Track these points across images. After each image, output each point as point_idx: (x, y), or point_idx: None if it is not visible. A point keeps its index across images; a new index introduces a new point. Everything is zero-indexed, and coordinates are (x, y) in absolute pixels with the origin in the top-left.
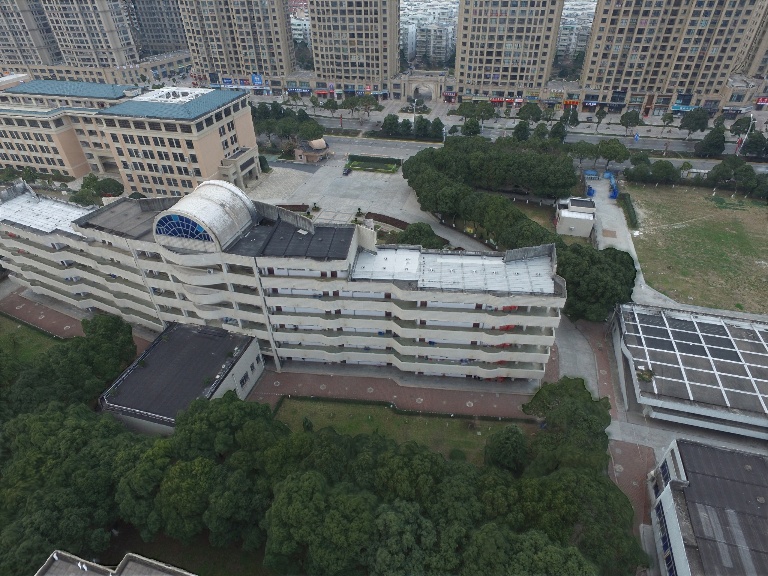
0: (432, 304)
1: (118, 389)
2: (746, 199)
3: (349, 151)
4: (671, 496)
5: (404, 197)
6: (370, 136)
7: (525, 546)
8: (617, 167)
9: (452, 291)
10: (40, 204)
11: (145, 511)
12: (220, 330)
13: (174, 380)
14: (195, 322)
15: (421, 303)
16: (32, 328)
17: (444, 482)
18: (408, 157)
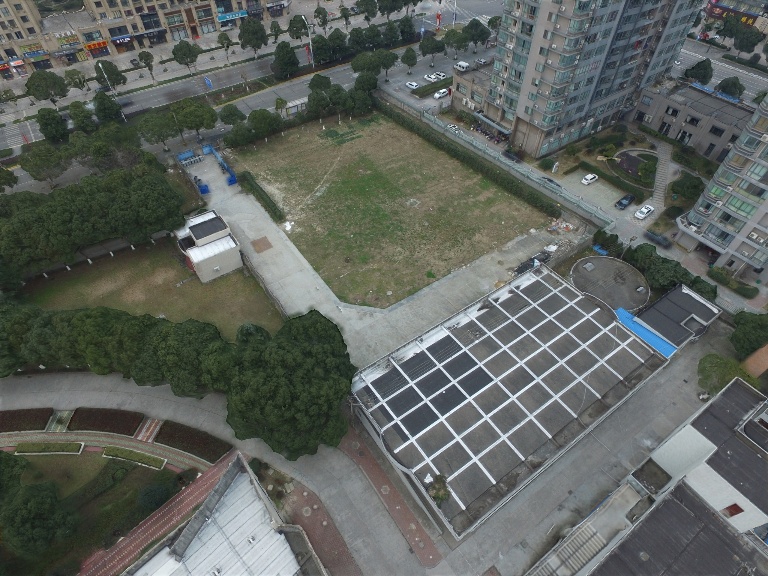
0: None
1: None
2: (352, 121)
3: None
4: None
5: None
6: None
7: None
8: None
9: None
10: None
11: None
12: None
13: None
14: None
15: None
16: None
17: None
18: None
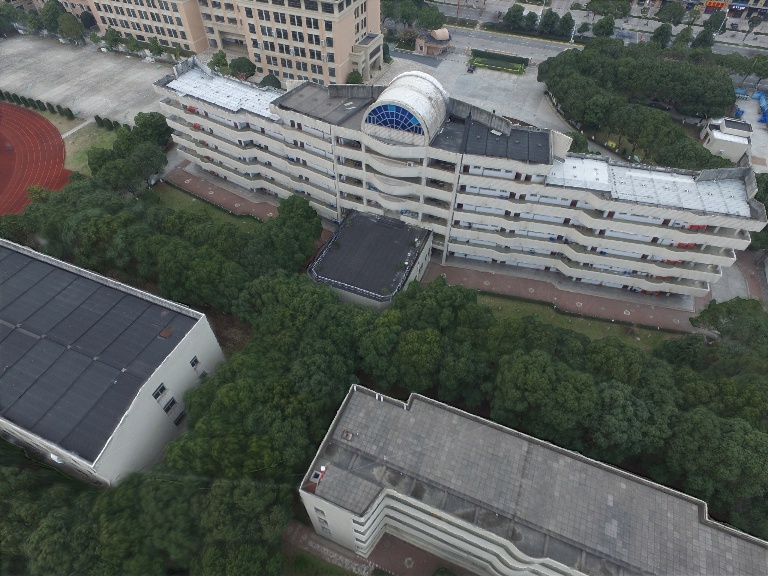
0: (619, 216)
1: (321, 265)
2: None
3: (469, 45)
4: None
5: (536, 102)
6: (489, 29)
7: (736, 428)
8: (766, 87)
9: (647, 205)
10: (214, 81)
11: (386, 366)
12: (398, 221)
13: (368, 262)
14: (373, 211)
15: (609, 214)
16: (207, 202)
17: (649, 372)
18: (533, 57)
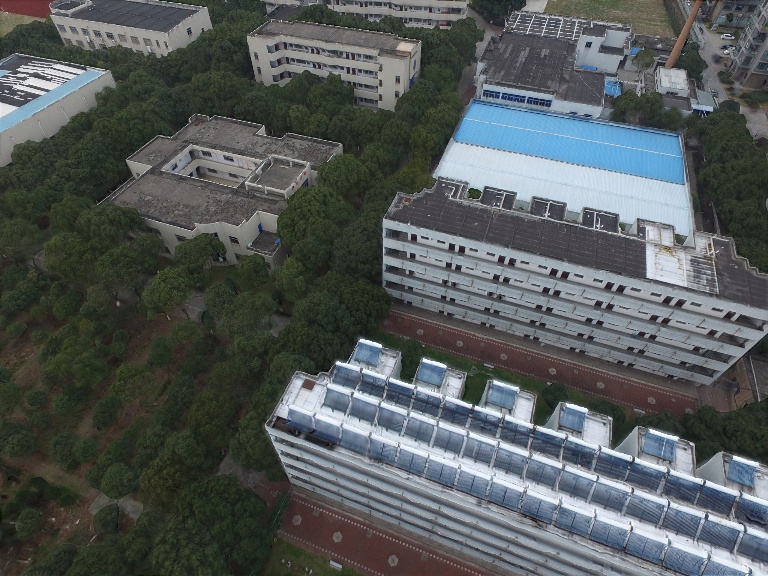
0: None
1: None
2: None
3: None
4: (490, 39)
5: None
6: None
7: None
8: None
9: None
10: None
11: None
12: None
13: None
14: (294, 3)
15: None
16: None
17: (404, 27)
18: None
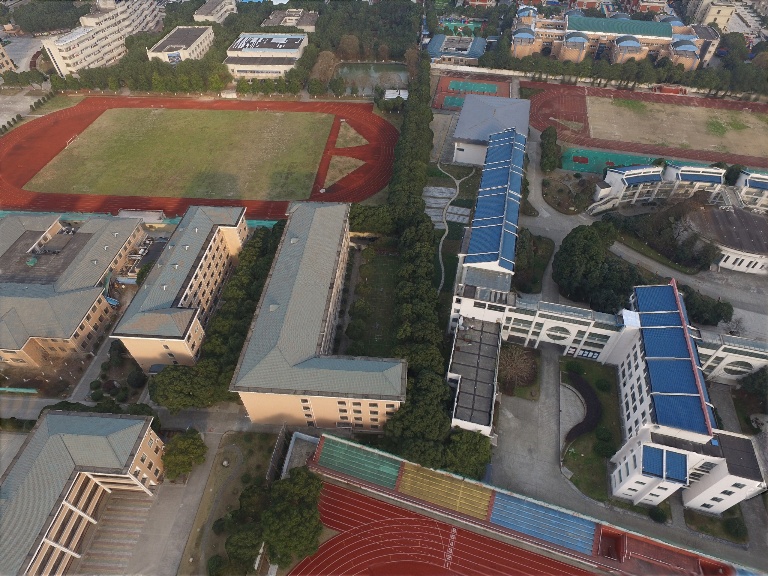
0: None
1: None
2: None
3: None
4: None
5: (42, 38)
6: None
7: None
8: None
9: None
10: None
11: None
12: (134, 34)
13: None
14: None
15: None
16: None
17: None
18: None
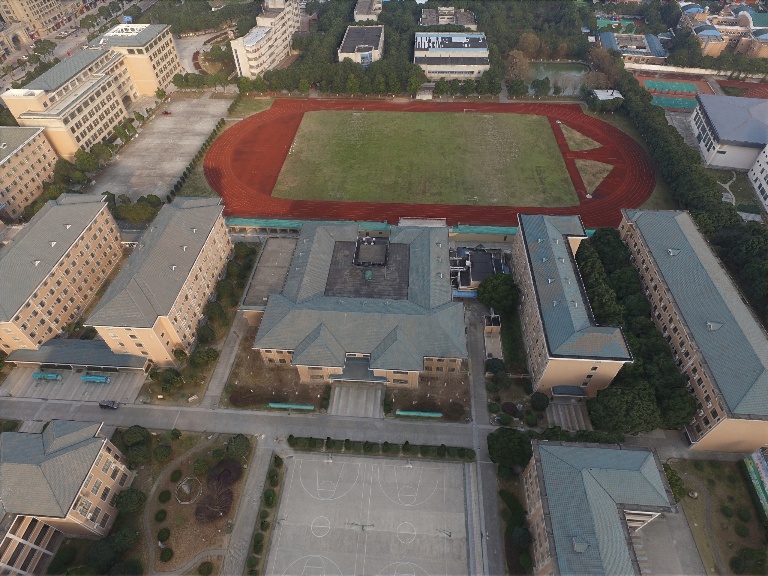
0: None
1: None
2: None
3: None
4: None
5: (189, 39)
6: None
7: None
8: None
9: None
10: None
11: None
12: None
13: None
14: None
15: None
16: None
17: None
18: None
